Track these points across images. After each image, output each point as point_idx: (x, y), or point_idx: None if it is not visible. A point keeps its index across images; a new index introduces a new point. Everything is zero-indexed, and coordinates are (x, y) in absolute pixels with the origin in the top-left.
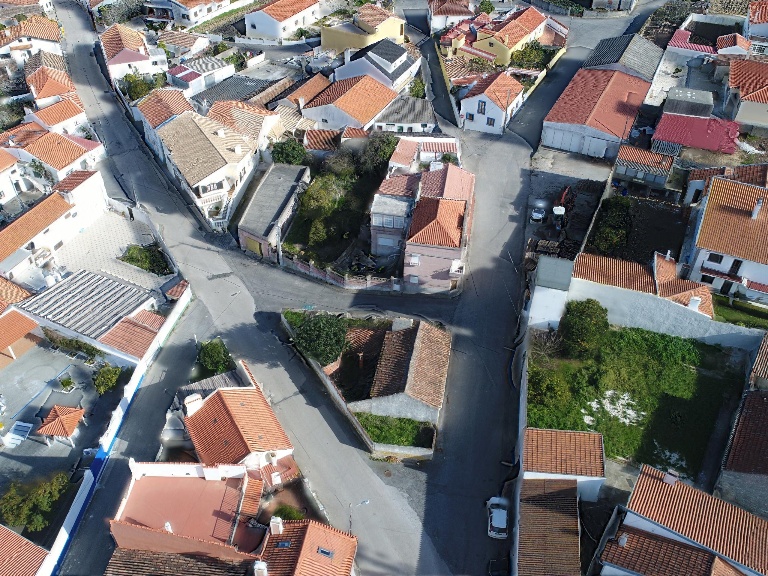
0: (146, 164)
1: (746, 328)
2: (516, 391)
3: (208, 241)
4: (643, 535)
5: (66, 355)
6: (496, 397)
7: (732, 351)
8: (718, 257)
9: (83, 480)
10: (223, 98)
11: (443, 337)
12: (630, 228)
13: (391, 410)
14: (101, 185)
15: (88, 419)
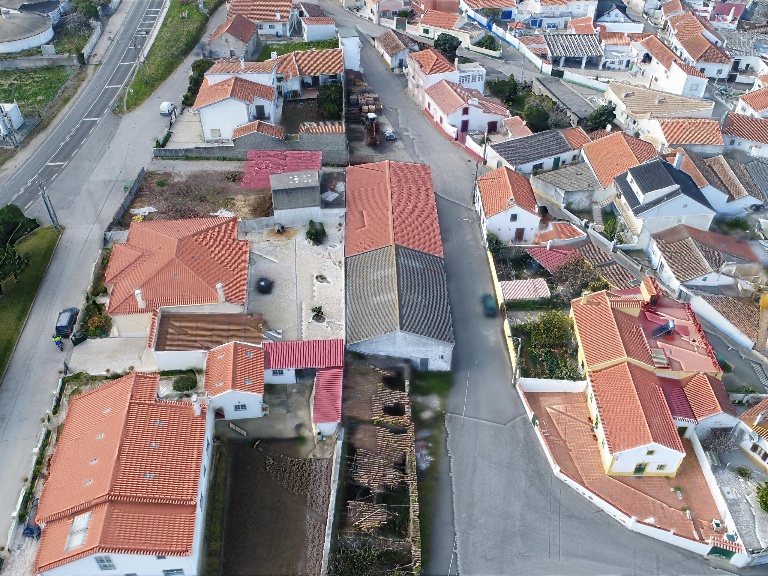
0: None
1: None
2: None
3: None
4: None
5: None
6: None
7: None
8: None
9: None
10: (767, 171)
11: None
12: None
13: None
14: None
15: None
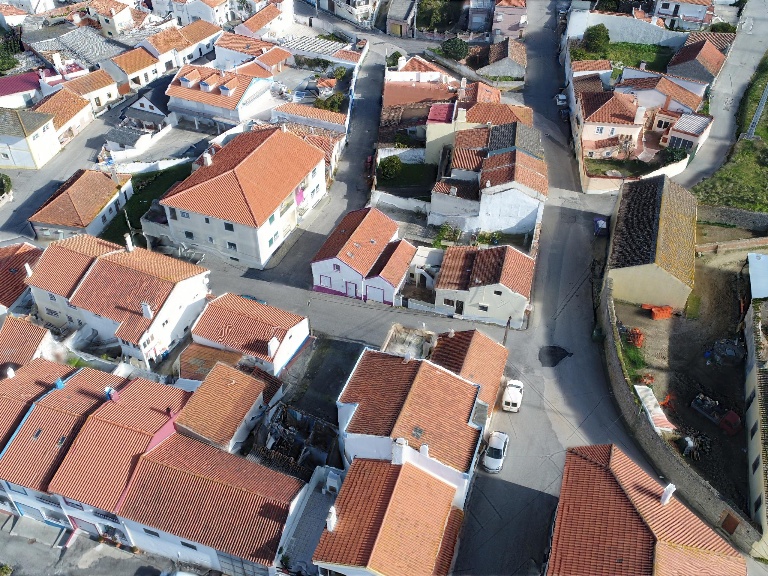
0: (304, 6)
1: (681, 32)
2: (563, 67)
3: (365, 32)
4: (631, 79)
5: (308, 71)
6: (552, 71)
7: (675, 48)
8: (667, 5)
9: (350, 98)
10: None
11: (522, 45)
12: (619, 3)
13: (500, 71)
14: (292, 5)
15: (335, 89)
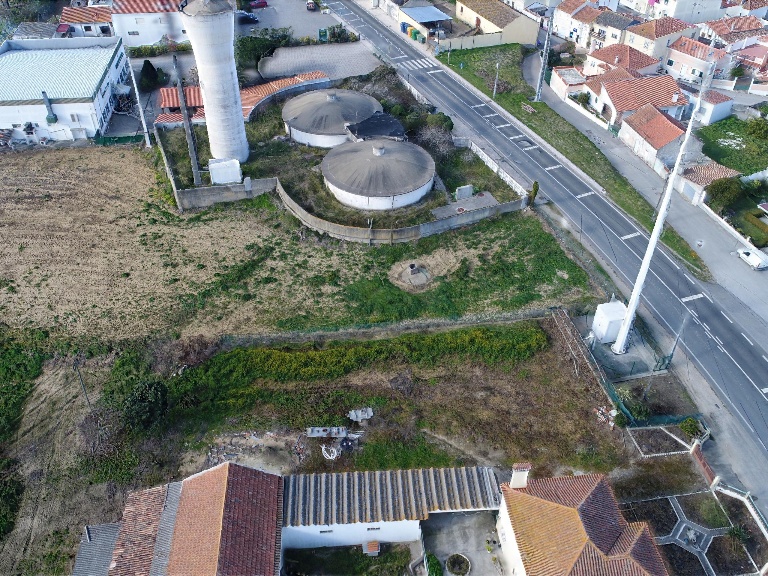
0: None
1: (752, 175)
2: None
3: None
4: None
5: None
6: None
7: None
8: None
9: None
10: None
11: None
12: None
13: None
14: None
15: None
